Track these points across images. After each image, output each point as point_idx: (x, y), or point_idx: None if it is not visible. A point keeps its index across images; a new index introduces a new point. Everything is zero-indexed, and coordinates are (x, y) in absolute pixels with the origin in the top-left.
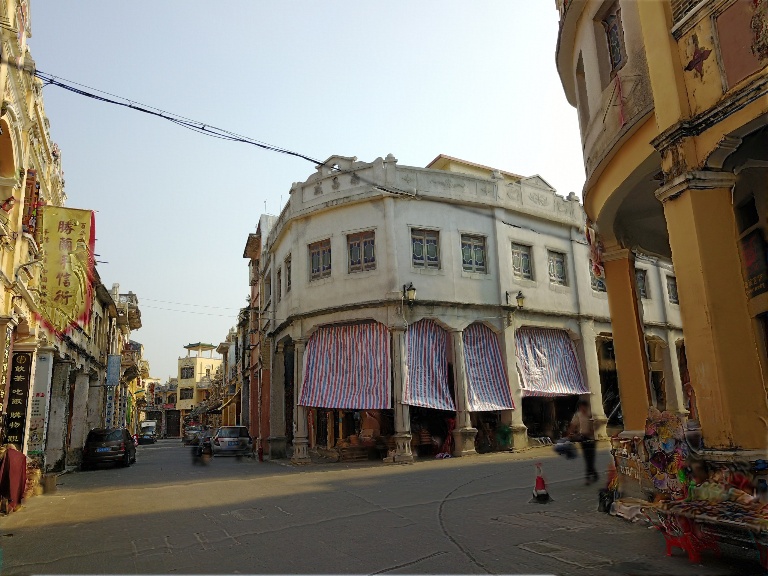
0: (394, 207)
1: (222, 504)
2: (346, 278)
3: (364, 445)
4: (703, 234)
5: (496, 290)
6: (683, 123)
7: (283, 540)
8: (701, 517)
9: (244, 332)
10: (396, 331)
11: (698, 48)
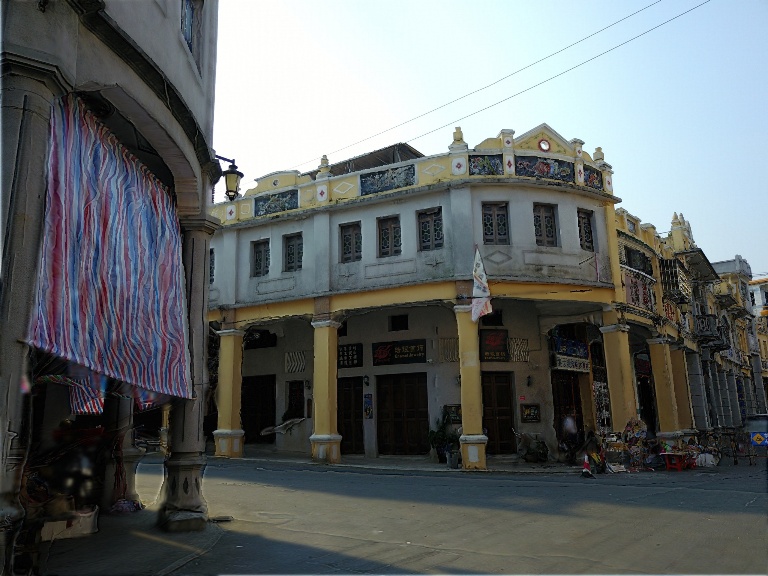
0: None
1: None
2: None
3: None
4: None
5: None
6: None
7: None
8: None
9: None
10: None
11: None
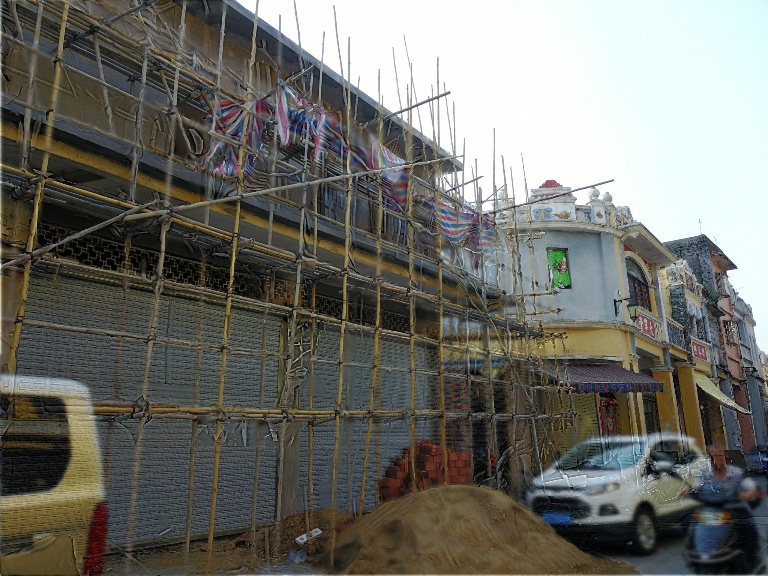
0: None
1: None
2: None
3: None
4: None
5: None
6: None
7: None
8: None
9: (707, 314)
10: None
11: None
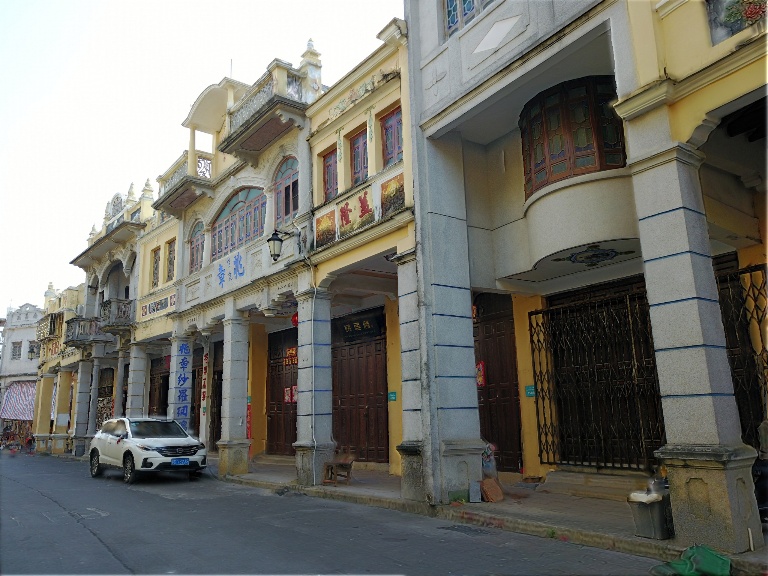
0: None
1: None
2: (26, 361)
3: None
4: (37, 391)
5: None
6: (38, 367)
7: None
8: None
9: None
10: None
11: None
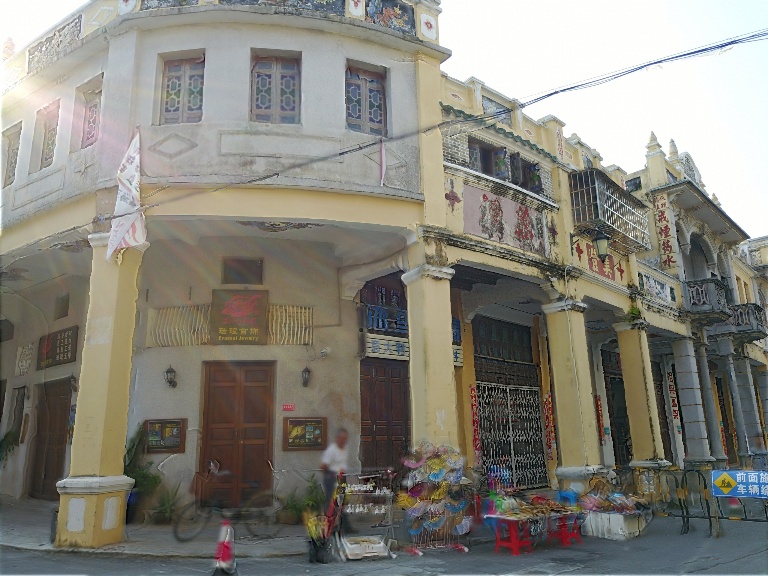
0: None
1: None
2: None
3: None
4: None
5: None
6: None
7: None
8: (554, 515)
9: None
10: None
11: (453, 190)
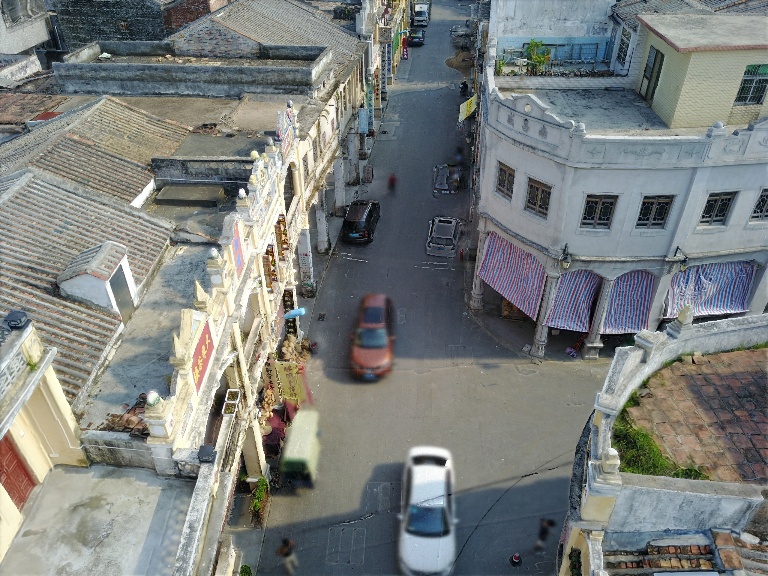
0: (573, 176)
1: (382, 458)
2: (521, 214)
3: (520, 315)
4: None
5: (667, 243)
6: None
7: (379, 569)
8: None
9: None
10: (550, 278)
11: None
